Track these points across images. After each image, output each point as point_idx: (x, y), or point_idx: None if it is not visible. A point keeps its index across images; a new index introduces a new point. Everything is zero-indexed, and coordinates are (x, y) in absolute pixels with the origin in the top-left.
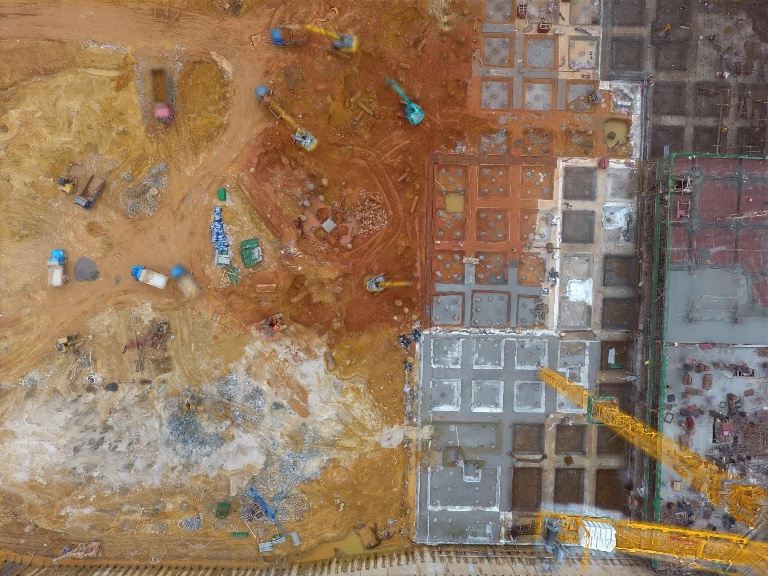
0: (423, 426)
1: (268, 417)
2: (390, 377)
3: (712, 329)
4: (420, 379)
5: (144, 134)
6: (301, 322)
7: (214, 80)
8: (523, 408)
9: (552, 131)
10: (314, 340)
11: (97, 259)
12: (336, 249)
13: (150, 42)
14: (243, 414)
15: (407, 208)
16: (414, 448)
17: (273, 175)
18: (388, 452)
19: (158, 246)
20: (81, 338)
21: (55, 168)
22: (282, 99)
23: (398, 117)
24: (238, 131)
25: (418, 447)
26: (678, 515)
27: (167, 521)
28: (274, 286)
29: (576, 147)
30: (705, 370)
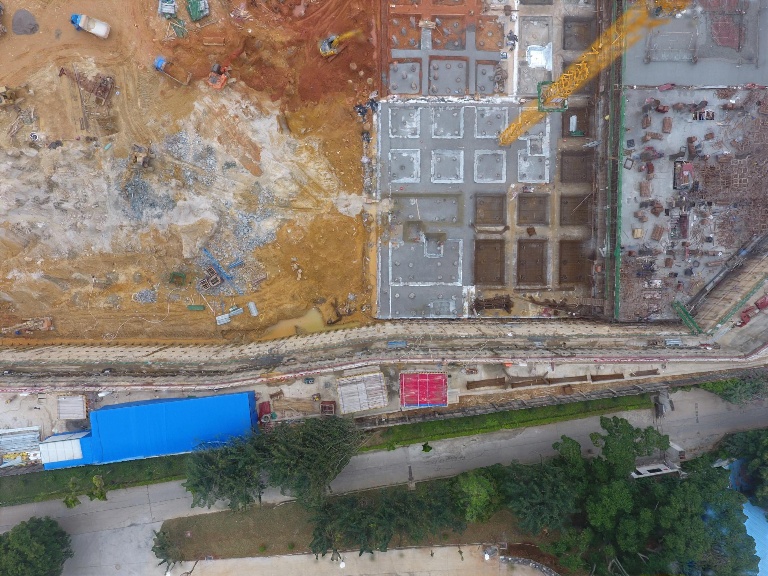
0: (382, 199)
1: (220, 178)
2: (346, 144)
3: (671, 71)
4: (378, 151)
5: None
6: (253, 86)
7: None
8: (484, 180)
9: None
10: (266, 101)
11: (36, 11)
12: (288, 17)
13: None
14: (194, 175)
15: None
16: (374, 224)
17: None
18: (346, 220)
19: None
20: (22, 95)
21: None
22: None
23: None
24: None
25: (378, 222)
26: (639, 260)
27: (121, 294)
28: (222, 38)
29: None
30: (664, 110)
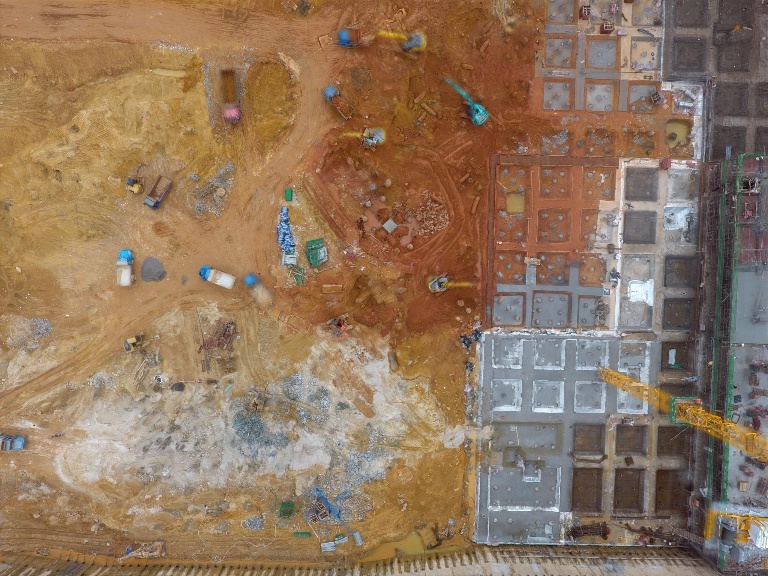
0: (484, 426)
1: (333, 417)
2: (452, 377)
3: None
4: (481, 379)
5: (211, 134)
6: (364, 322)
7: (281, 81)
8: (583, 408)
9: (614, 132)
10: (378, 340)
11: (164, 259)
12: (397, 249)
13: (218, 43)
14: (308, 414)
15: (468, 209)
16: (474, 448)
17: (338, 175)
18: (450, 452)
19: (225, 246)
20: (148, 338)
21: (123, 168)
22: (349, 100)
23: (461, 118)
24: (304, 132)
25: (478, 447)
26: None
27: (230, 521)
28: (340, 286)
29: (637, 148)
30: None
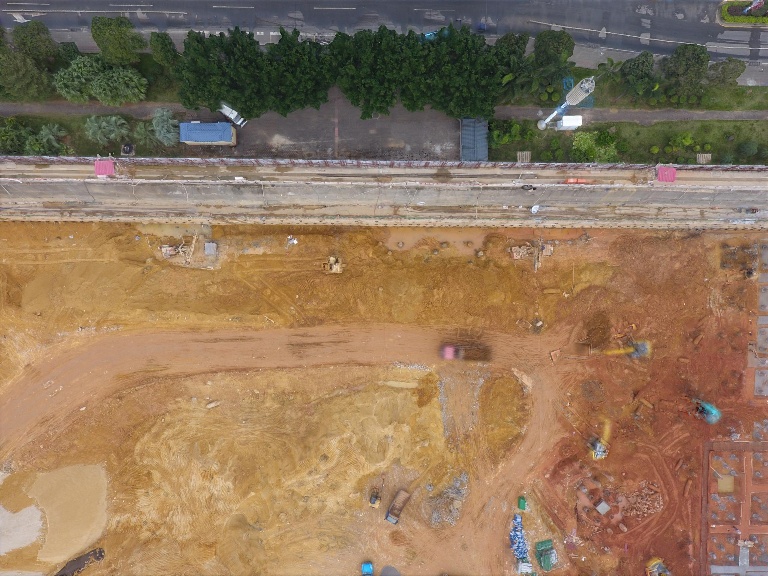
0: None
1: None
2: None
3: None
4: None
5: (444, 445)
6: None
7: (512, 392)
8: None
9: None
10: None
11: (401, 568)
12: (611, 531)
13: (453, 360)
14: None
15: (680, 491)
16: None
17: (564, 476)
18: None
19: (460, 554)
20: None
21: (361, 482)
22: (579, 410)
23: (678, 410)
24: (535, 441)
25: None
26: None
27: None
28: None
29: None
30: None
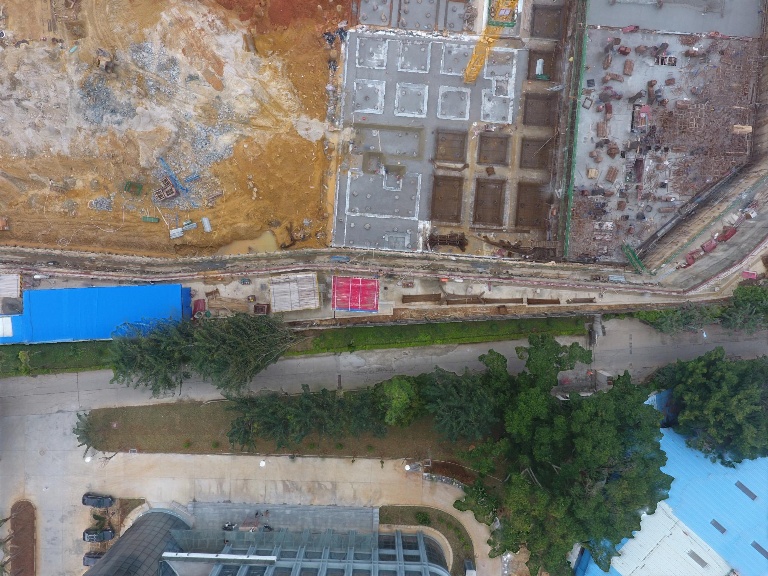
0: (345, 128)
1: (182, 90)
2: (312, 69)
3: (636, 14)
4: (344, 80)
5: None
6: (223, 4)
7: None
8: (447, 117)
9: None
10: (234, 19)
11: None
12: None
13: None
14: (157, 85)
15: None
16: (335, 153)
17: None
18: (306, 143)
19: None
20: None
21: None
22: None
23: None
24: None
25: (339, 151)
26: (590, 198)
27: (77, 200)
28: None
29: None
30: (626, 52)
